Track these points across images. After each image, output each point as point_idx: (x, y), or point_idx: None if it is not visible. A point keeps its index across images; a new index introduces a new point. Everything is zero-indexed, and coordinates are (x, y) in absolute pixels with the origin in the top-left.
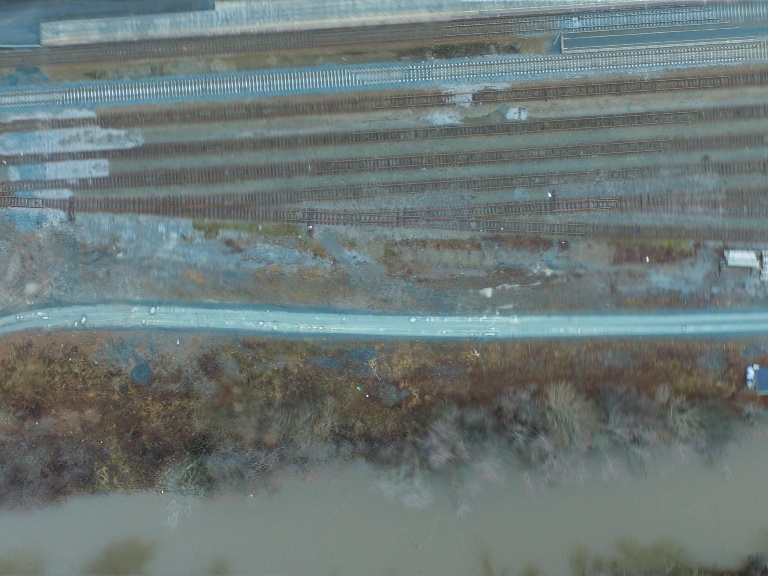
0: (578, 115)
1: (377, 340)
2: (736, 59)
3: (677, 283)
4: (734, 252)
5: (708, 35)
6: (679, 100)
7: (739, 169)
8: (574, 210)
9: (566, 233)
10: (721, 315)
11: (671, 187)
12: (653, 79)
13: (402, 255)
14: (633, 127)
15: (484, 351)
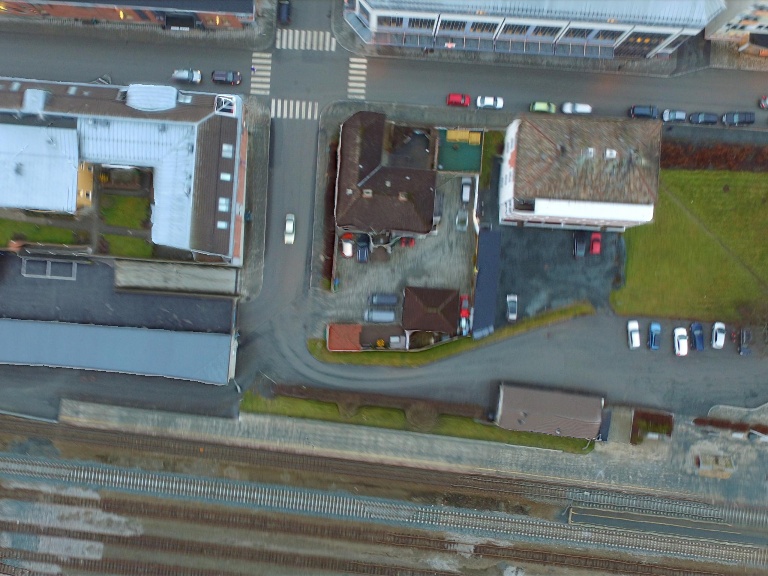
0: None
1: None
2: (733, 559)
3: None
4: None
5: (710, 535)
6: None
7: None
8: None
9: None
10: None
11: None
12: (651, 564)
13: None
14: None
15: None
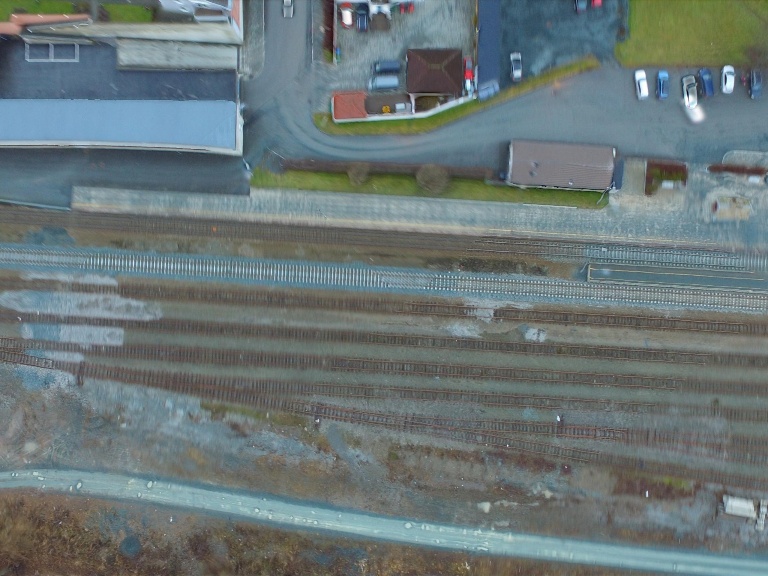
0: (596, 343)
1: (370, 541)
2: (757, 308)
3: (673, 521)
4: (733, 500)
5: (733, 283)
6: (697, 341)
7: (747, 417)
8: (581, 436)
9: (570, 458)
10: (713, 558)
11: (679, 426)
12: (674, 318)
13: (405, 460)
14: (648, 363)
15: (475, 565)
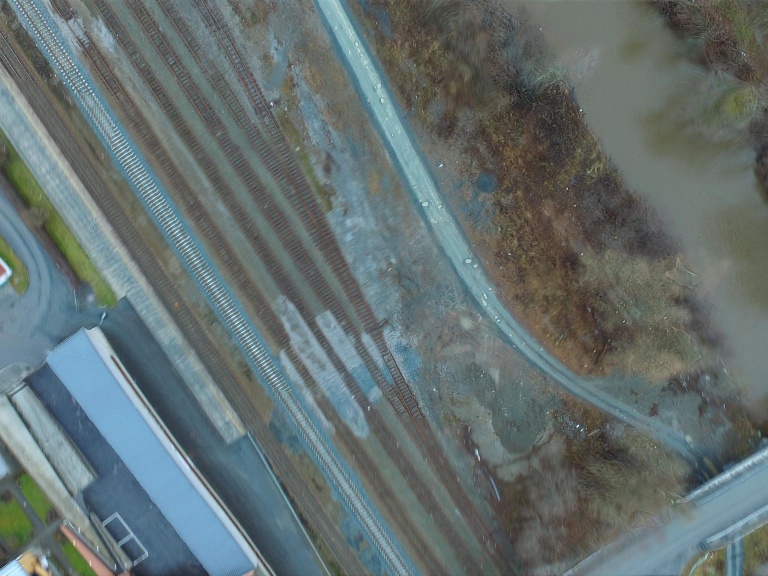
0: None
1: None
2: None
3: None
4: None
5: None
6: None
7: None
8: None
9: None
10: None
11: None
12: None
13: (250, 7)
14: None
15: None
